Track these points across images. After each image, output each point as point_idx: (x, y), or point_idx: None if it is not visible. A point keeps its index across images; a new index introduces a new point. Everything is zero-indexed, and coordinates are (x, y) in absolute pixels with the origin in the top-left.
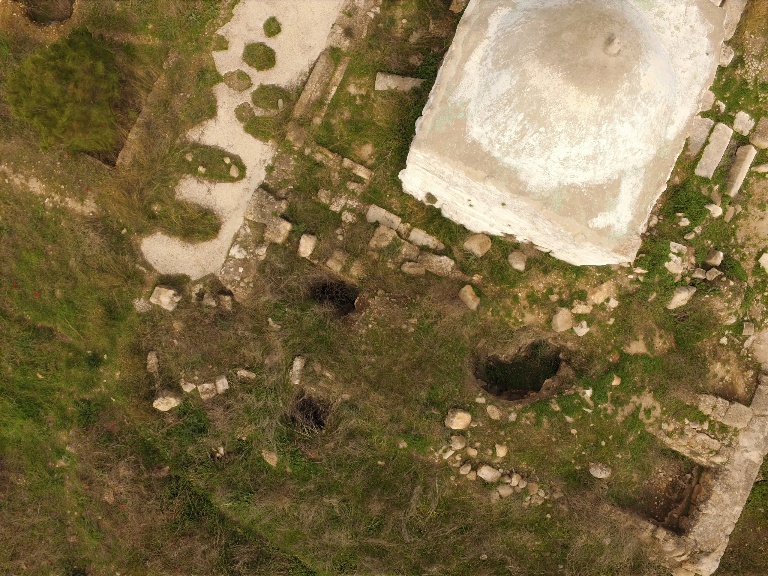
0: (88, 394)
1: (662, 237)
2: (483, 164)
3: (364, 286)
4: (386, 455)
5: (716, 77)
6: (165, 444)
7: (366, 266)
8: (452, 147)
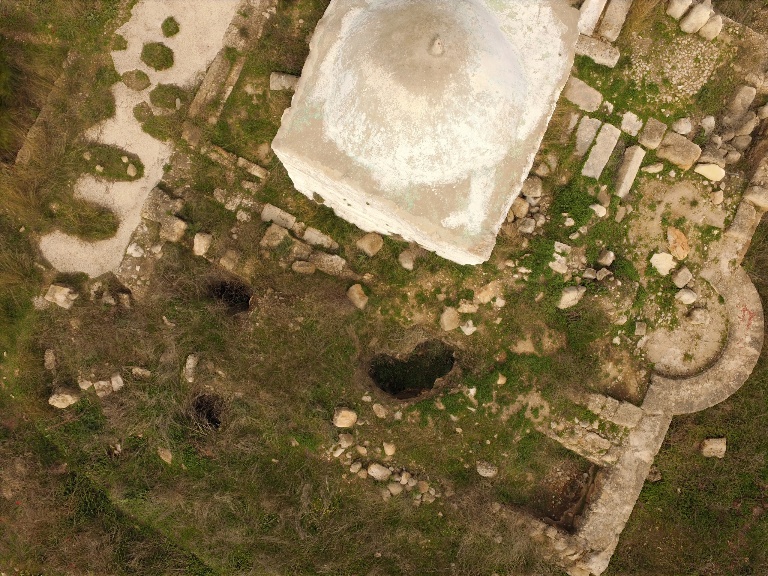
0: None
1: (548, 237)
2: (339, 163)
3: (253, 285)
4: (279, 453)
5: (604, 78)
6: (63, 441)
7: (258, 265)
8: (310, 147)
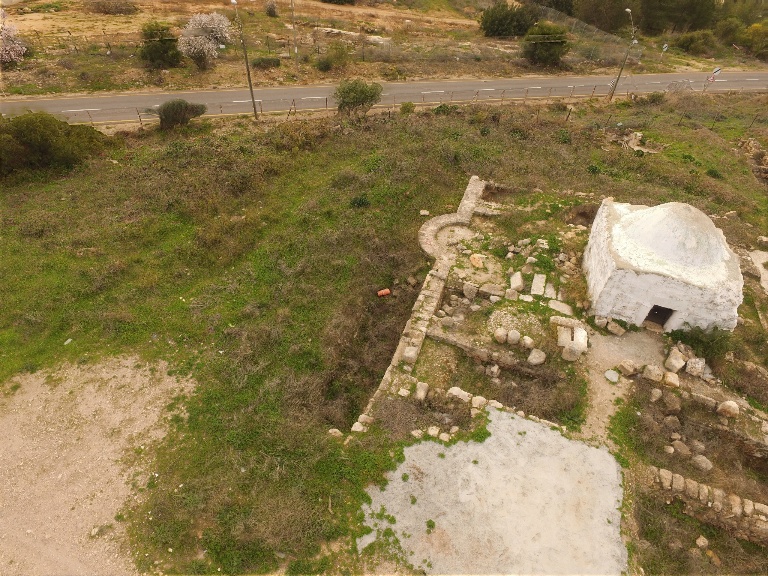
0: (765, 218)
1: (552, 252)
2: None
3: None
4: None
5: None
6: None
7: None
8: None
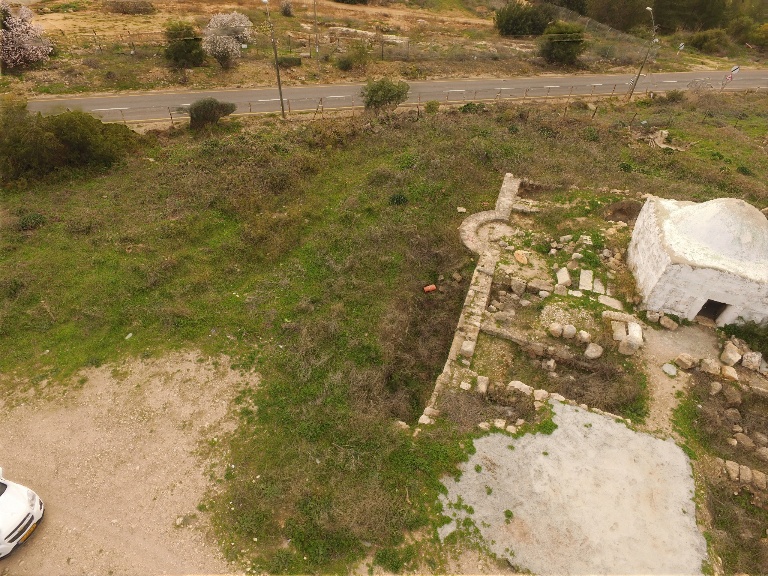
0: None
1: (596, 248)
2: None
3: None
4: None
5: None
6: None
7: None
8: None
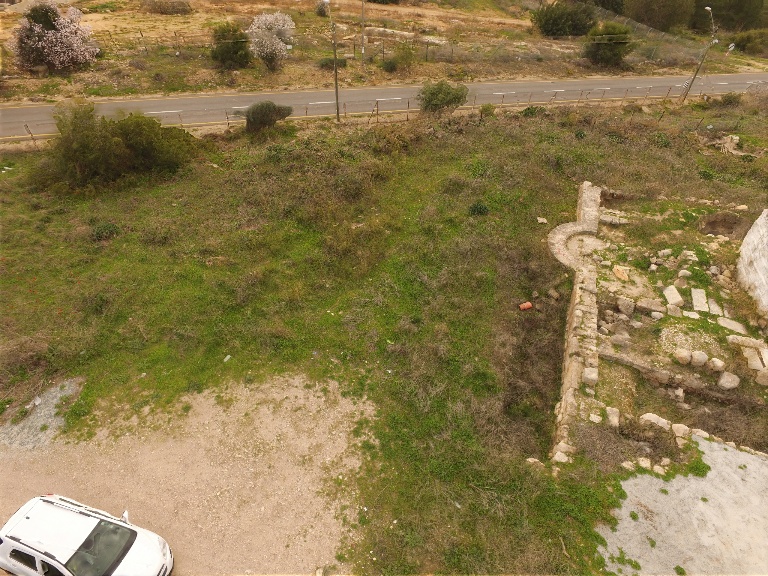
0: None
1: (702, 264)
2: None
3: None
4: None
5: None
6: None
7: None
8: None
